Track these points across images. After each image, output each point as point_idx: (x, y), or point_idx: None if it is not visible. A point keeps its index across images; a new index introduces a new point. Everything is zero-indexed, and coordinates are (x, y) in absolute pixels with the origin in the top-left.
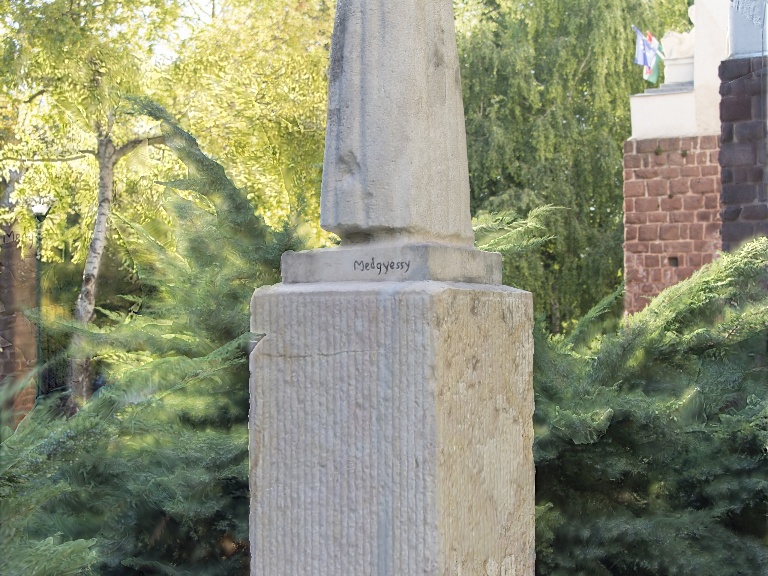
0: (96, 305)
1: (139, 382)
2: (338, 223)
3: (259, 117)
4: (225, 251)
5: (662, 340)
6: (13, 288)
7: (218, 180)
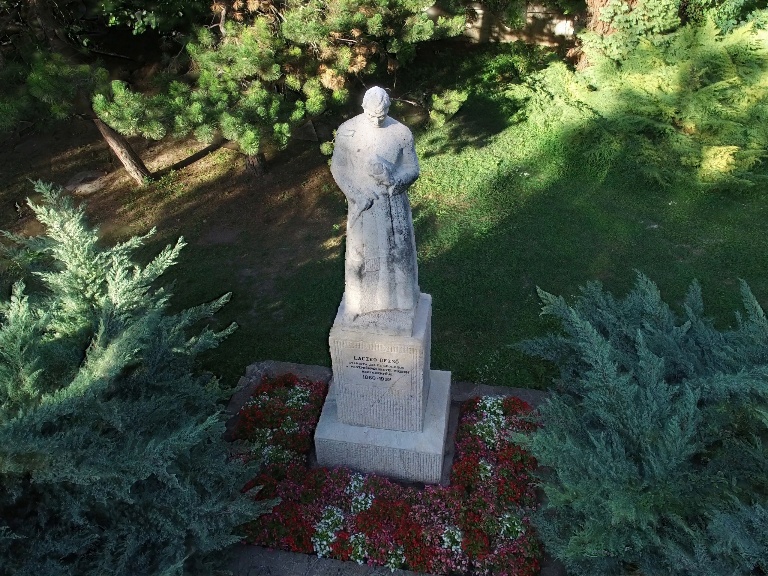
0: None
1: None
2: None
3: None
4: None
5: None
6: None
7: None
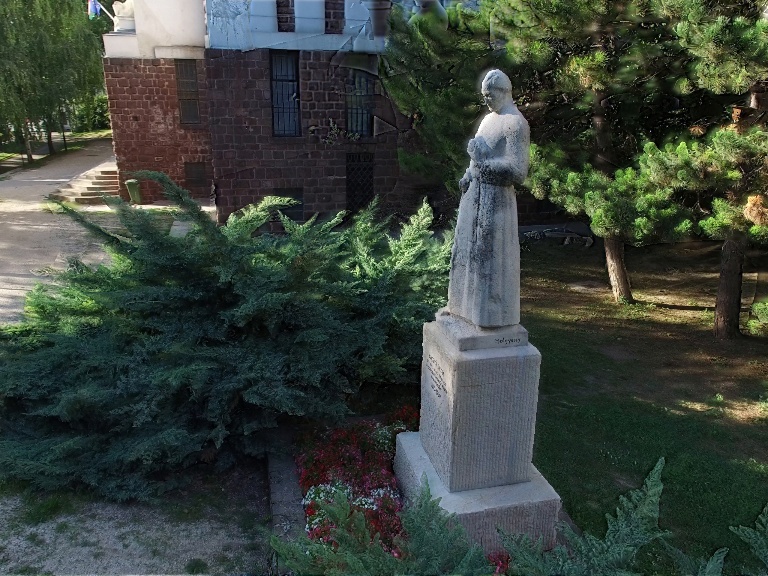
0: None
1: None
2: (490, 325)
3: None
4: None
5: None
6: None
7: (201, 213)
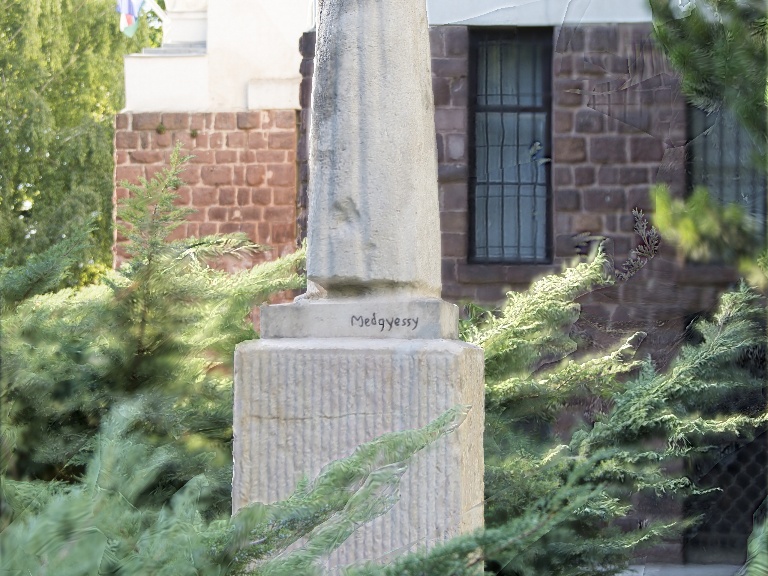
0: None
1: (379, 455)
2: (334, 274)
3: None
4: None
5: None
6: None
7: None
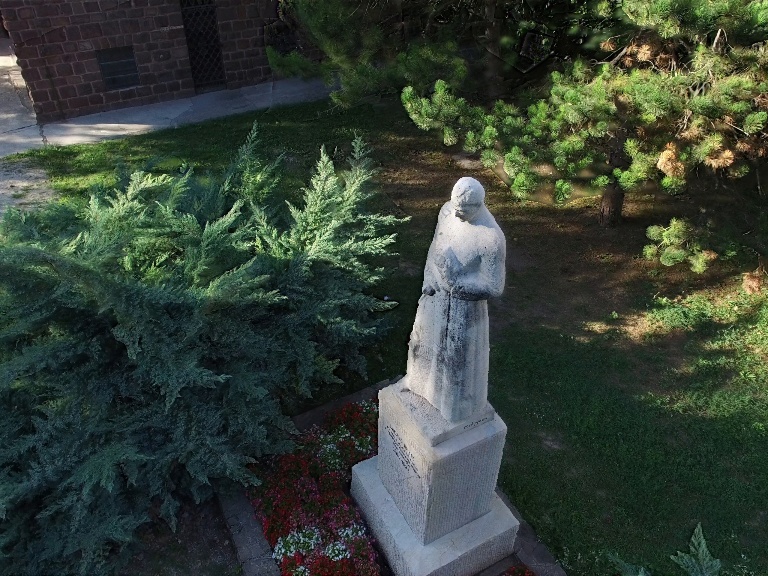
0: None
1: None
2: None
3: None
4: None
5: None
6: None
7: (79, 271)
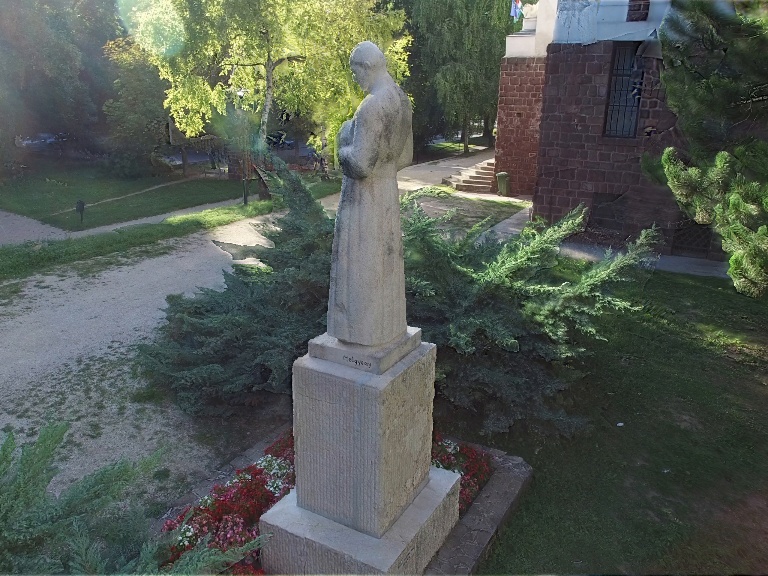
0: (268, 135)
1: None
2: (336, 336)
3: (337, 49)
4: (302, 225)
5: (504, 284)
6: (232, 125)
7: (298, 188)
